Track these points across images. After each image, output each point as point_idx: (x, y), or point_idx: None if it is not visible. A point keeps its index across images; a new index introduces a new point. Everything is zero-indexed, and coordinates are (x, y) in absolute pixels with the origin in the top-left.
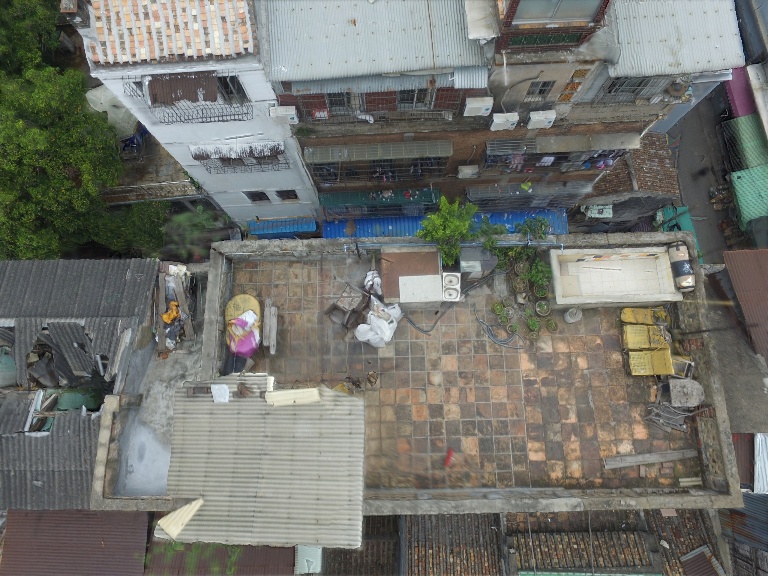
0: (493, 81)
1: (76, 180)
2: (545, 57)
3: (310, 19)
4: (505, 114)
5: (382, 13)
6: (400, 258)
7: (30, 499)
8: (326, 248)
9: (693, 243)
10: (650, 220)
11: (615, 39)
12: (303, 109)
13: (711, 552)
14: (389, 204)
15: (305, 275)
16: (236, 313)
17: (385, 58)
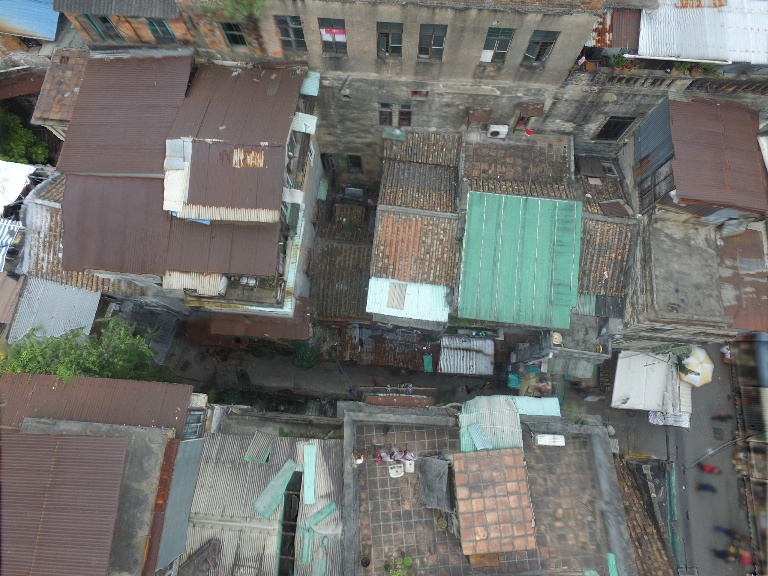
0: None
1: None
2: None
3: None
4: None
5: None
6: None
7: (114, 7)
8: None
9: None
10: None
11: None
12: None
13: (625, 202)
14: None
15: None
16: None
17: None
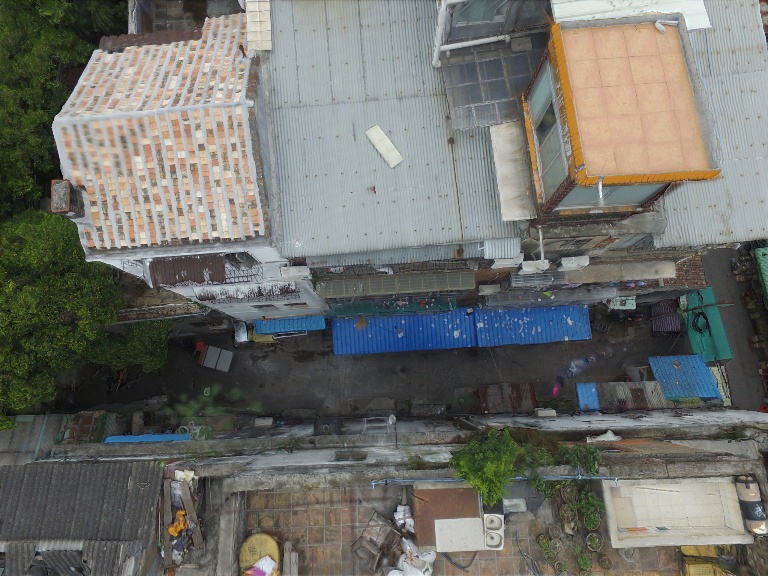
0: (524, 241)
1: (72, 324)
2: (585, 231)
3: (325, 187)
4: (535, 262)
5: (404, 179)
6: (435, 496)
7: None
8: (352, 485)
9: (764, 476)
10: (673, 303)
11: (661, 210)
12: (317, 270)
13: None
14: (403, 311)
15: (327, 499)
16: (252, 558)
17: (408, 230)
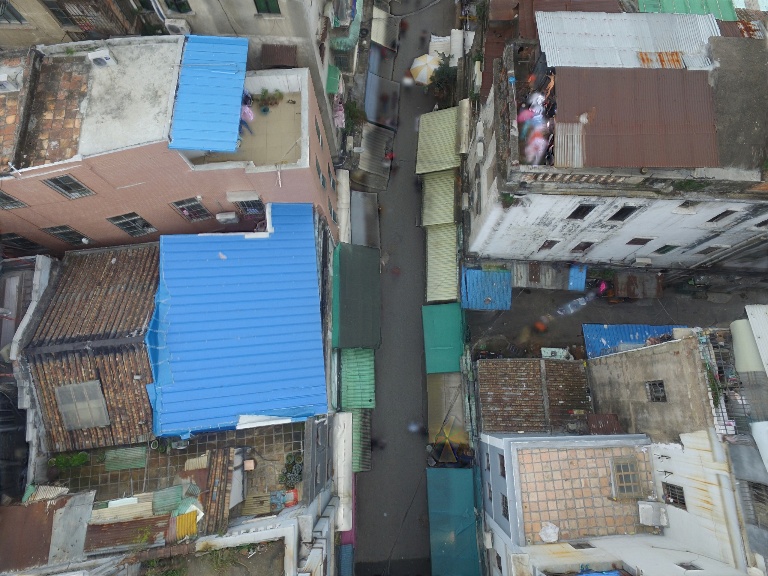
0: None
1: None
2: None
3: None
4: None
5: None
6: None
7: None
8: None
9: None
10: None
11: None
12: None
13: None
14: None
15: None
16: None
17: None
